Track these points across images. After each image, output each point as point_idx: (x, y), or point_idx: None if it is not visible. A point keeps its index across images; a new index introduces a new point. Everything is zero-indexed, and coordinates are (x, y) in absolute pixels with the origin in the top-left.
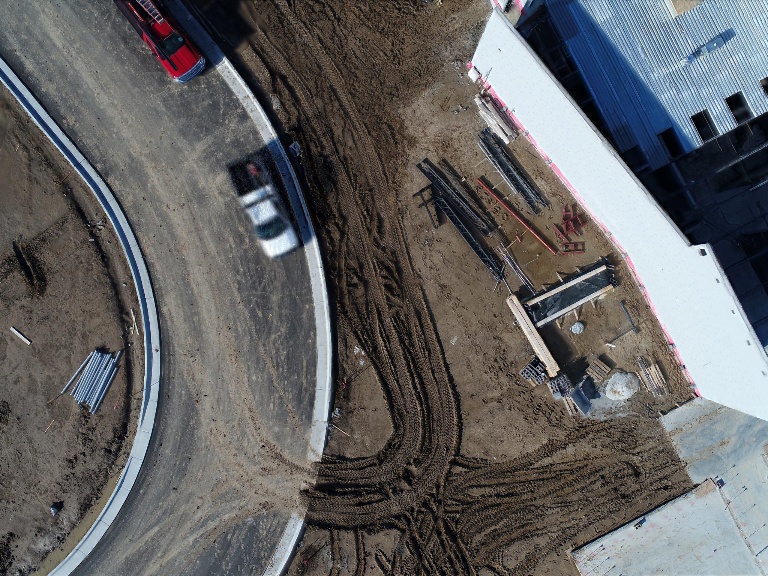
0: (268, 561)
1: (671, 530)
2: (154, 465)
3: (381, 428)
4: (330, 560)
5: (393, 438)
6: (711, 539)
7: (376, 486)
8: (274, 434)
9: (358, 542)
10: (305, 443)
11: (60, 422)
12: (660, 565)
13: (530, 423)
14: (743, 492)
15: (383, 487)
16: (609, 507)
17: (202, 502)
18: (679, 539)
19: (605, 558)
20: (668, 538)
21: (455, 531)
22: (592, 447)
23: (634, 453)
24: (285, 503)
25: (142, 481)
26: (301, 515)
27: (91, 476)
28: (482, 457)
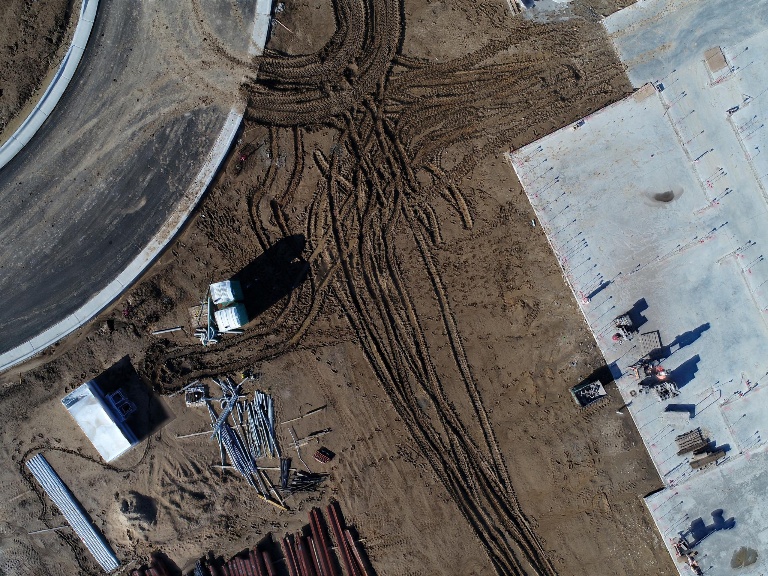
0: (206, 157)
1: (609, 134)
2: (95, 55)
3: (324, 26)
4: (268, 158)
5: (336, 36)
6: (649, 144)
7: (317, 85)
8: (217, 27)
9: (297, 141)
10: (247, 37)
11: (2, 9)
12: (597, 169)
13: (473, 24)
14: (682, 98)
15: (324, 86)
16: (549, 110)
17: (142, 95)
18: (617, 143)
19: (543, 159)
20: (606, 142)
21: (394, 132)
22: (534, 49)
23: (575, 56)
24: (225, 98)
25: (82, 72)
26: (241, 110)
27: (31, 65)
28: (424, 57)
